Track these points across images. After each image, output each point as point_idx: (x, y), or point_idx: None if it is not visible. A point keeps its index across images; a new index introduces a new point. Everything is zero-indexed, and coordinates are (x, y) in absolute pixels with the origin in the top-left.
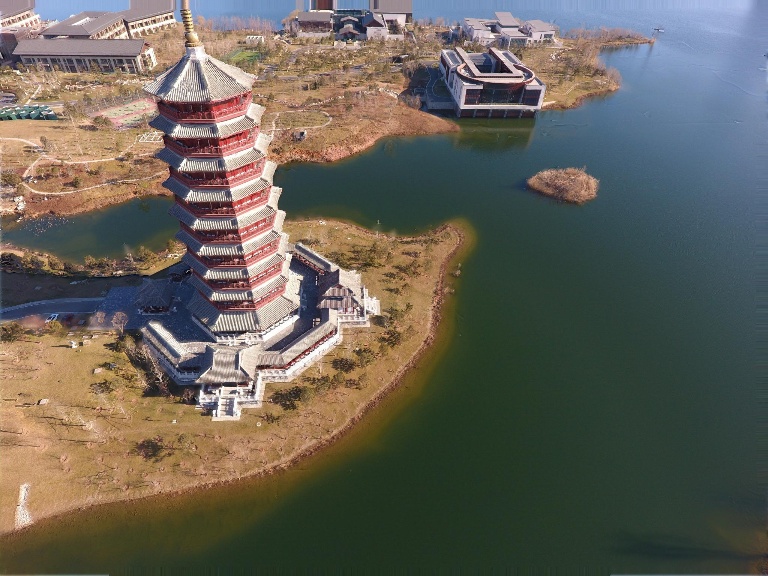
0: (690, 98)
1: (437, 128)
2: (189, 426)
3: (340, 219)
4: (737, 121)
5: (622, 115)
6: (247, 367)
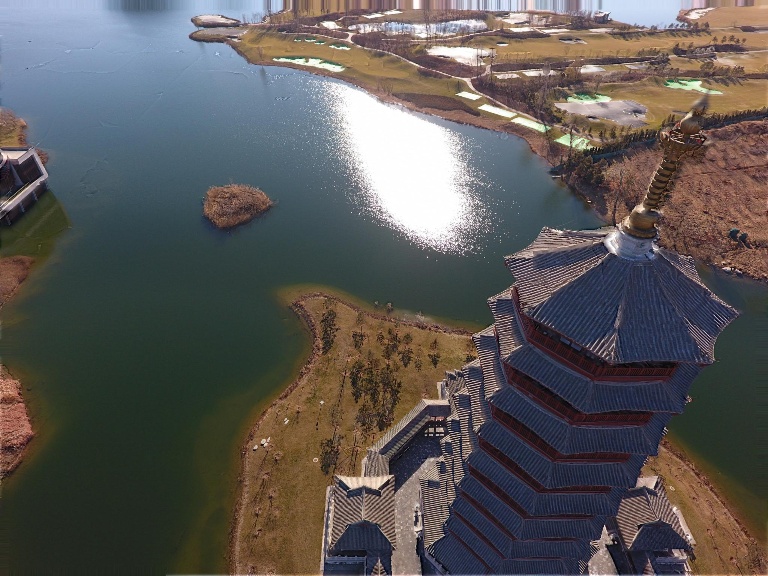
0: (90, 96)
1: (7, 279)
2: (717, 572)
3: (247, 422)
4: (159, 93)
5: (92, 137)
6: (646, 484)
